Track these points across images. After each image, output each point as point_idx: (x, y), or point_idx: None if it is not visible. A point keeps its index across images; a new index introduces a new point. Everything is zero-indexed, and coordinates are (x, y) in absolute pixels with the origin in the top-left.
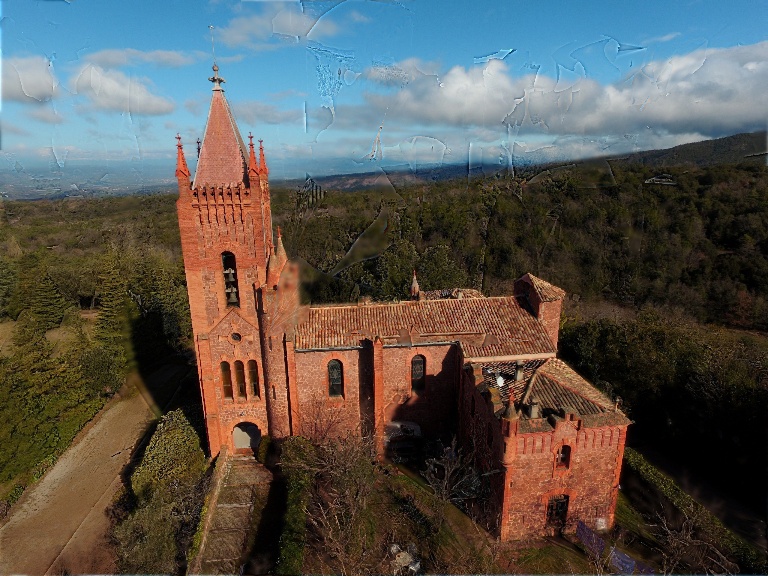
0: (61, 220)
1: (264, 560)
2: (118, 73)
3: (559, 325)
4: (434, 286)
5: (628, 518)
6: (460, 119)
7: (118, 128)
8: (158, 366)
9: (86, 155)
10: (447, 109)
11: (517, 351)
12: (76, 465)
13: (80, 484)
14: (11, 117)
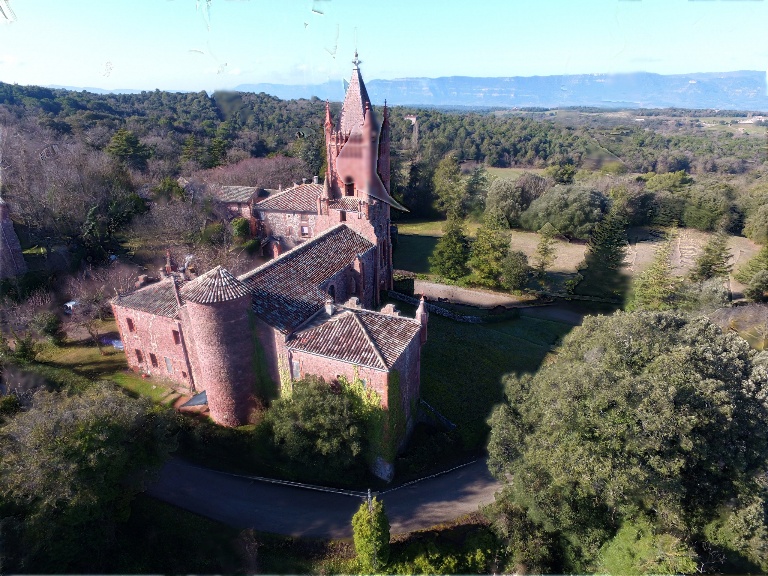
0: None
1: None
2: None
3: None
4: None
5: (121, 380)
6: (217, 96)
7: None
8: None
9: None
10: (220, 89)
11: None
12: None
13: (421, 290)
14: None
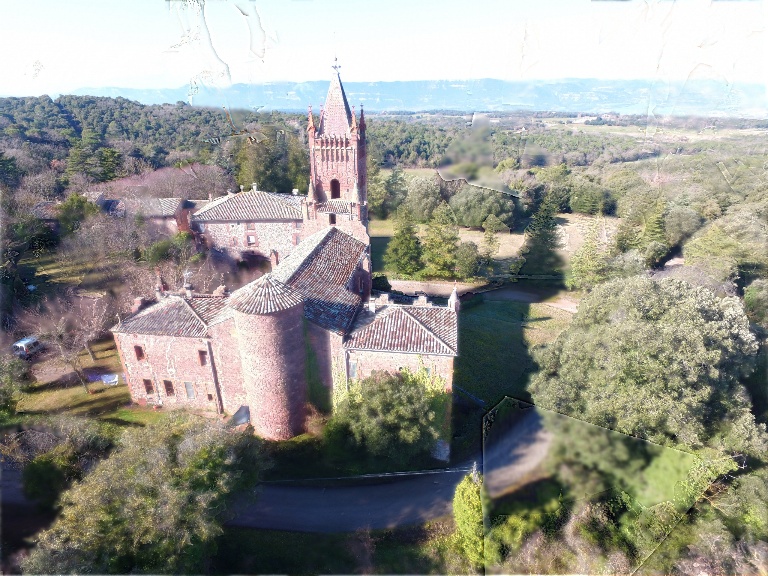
0: (752, 165)
1: None
2: (684, 6)
3: None
4: (592, 370)
5: (129, 416)
6: (228, 100)
7: (657, 71)
8: (534, 292)
9: (696, 97)
10: None
11: (226, 308)
12: (402, 285)
13: None
14: (763, 50)
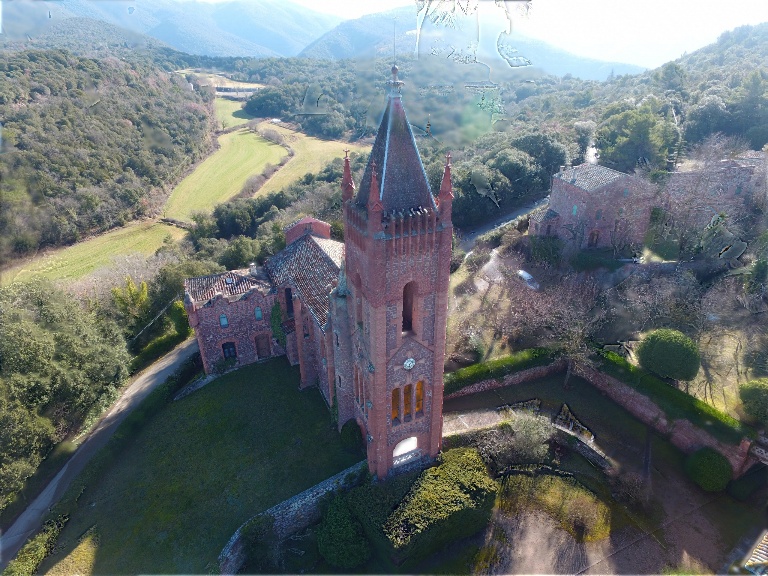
0: None
1: (488, 400)
2: None
3: (145, 295)
4: None
5: None
6: (370, 112)
7: None
8: None
9: None
10: (379, 106)
11: None
12: None
13: None
14: None
